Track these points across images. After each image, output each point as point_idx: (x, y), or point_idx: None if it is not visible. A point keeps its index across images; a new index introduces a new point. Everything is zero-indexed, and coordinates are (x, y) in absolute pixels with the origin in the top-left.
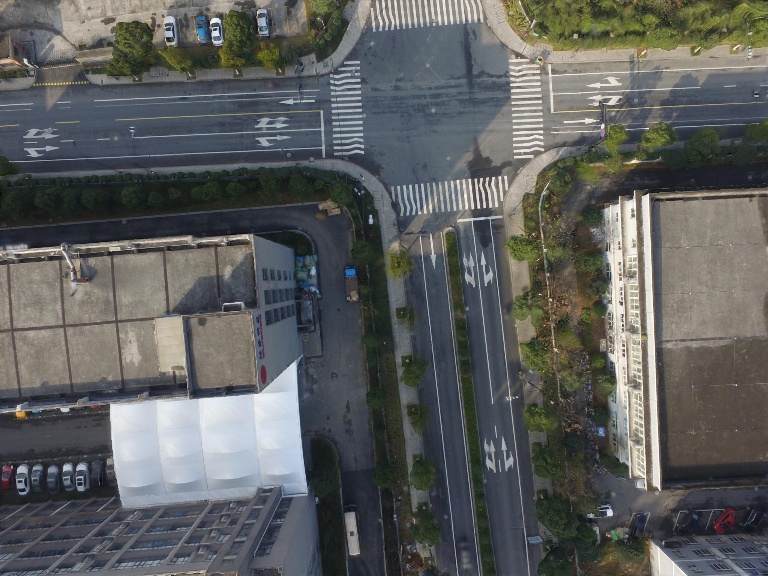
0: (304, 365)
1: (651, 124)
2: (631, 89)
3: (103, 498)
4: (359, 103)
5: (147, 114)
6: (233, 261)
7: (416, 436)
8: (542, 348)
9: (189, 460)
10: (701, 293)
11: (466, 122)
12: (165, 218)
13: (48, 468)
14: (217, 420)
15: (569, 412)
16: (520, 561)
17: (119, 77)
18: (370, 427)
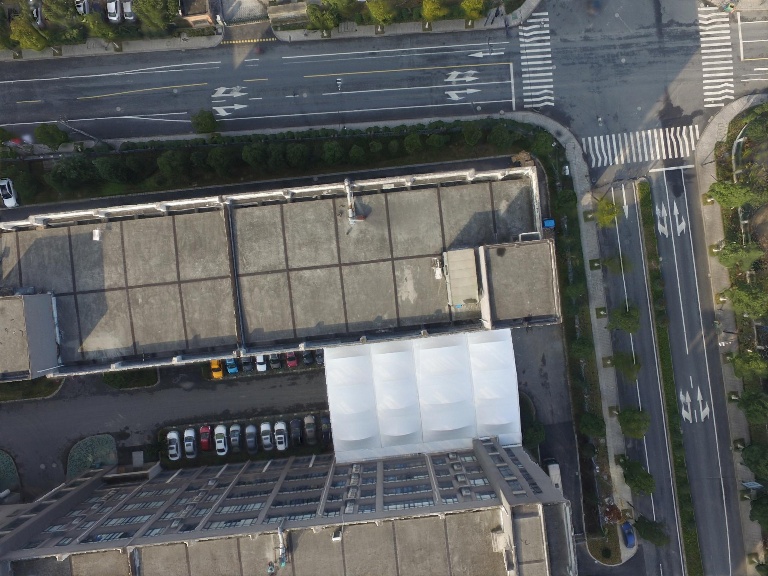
0: None
1: None
2: None
3: (303, 457)
4: (549, 55)
5: (336, 70)
6: (508, 196)
7: (612, 388)
8: (759, 291)
9: (408, 412)
10: None
11: (656, 71)
12: (357, 174)
13: (245, 428)
14: (436, 371)
15: None
16: (718, 511)
17: (307, 33)
18: (566, 380)
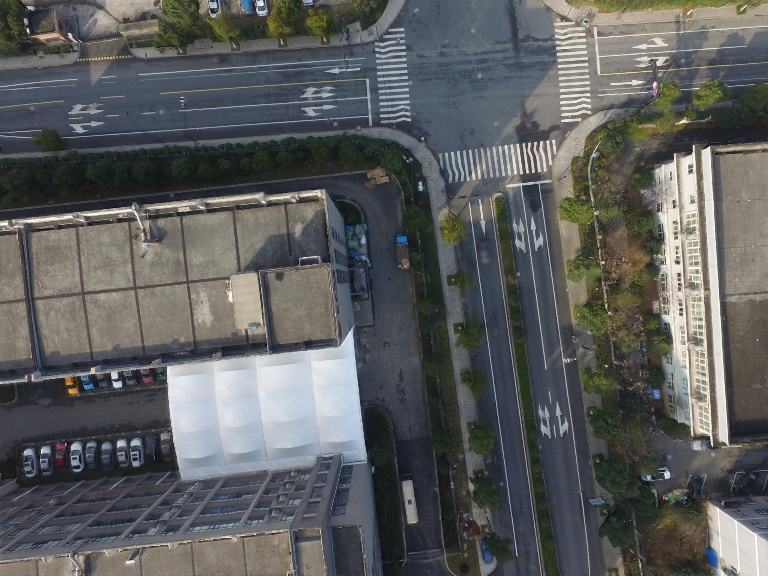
0: (356, 335)
1: (698, 84)
2: (677, 49)
3: (158, 473)
4: (405, 70)
5: (192, 87)
6: (303, 218)
7: (470, 403)
8: (600, 308)
9: (249, 430)
10: (763, 246)
11: (513, 87)
12: (213, 191)
13: (102, 444)
14: (276, 388)
15: (623, 375)
16: (577, 526)
17: (163, 50)
18: (424, 396)
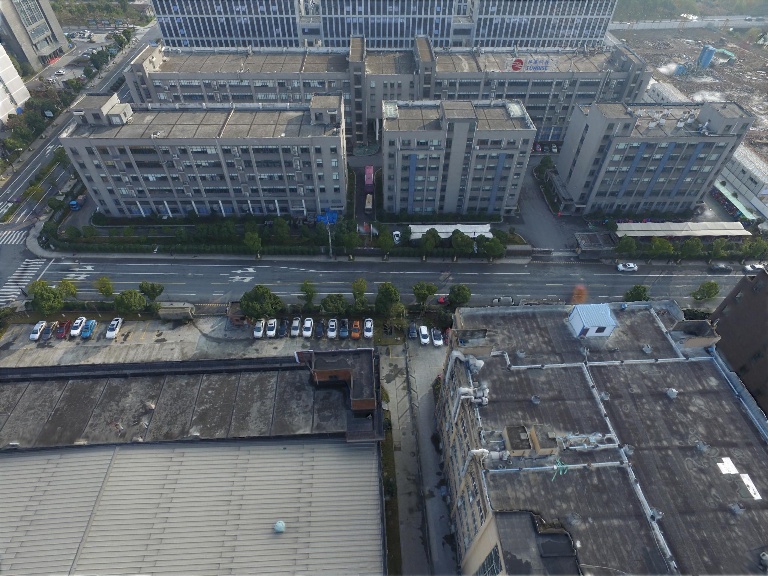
0: None
1: None
2: None
3: None
4: (7, 284)
5: None
6: None
7: None
8: None
9: None
10: None
11: None
12: None
13: None
14: None
15: None
16: None
17: None
18: None
